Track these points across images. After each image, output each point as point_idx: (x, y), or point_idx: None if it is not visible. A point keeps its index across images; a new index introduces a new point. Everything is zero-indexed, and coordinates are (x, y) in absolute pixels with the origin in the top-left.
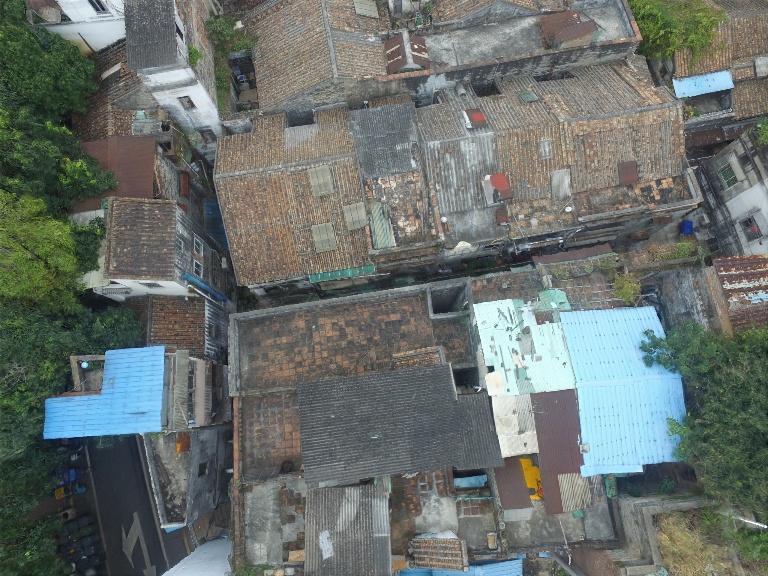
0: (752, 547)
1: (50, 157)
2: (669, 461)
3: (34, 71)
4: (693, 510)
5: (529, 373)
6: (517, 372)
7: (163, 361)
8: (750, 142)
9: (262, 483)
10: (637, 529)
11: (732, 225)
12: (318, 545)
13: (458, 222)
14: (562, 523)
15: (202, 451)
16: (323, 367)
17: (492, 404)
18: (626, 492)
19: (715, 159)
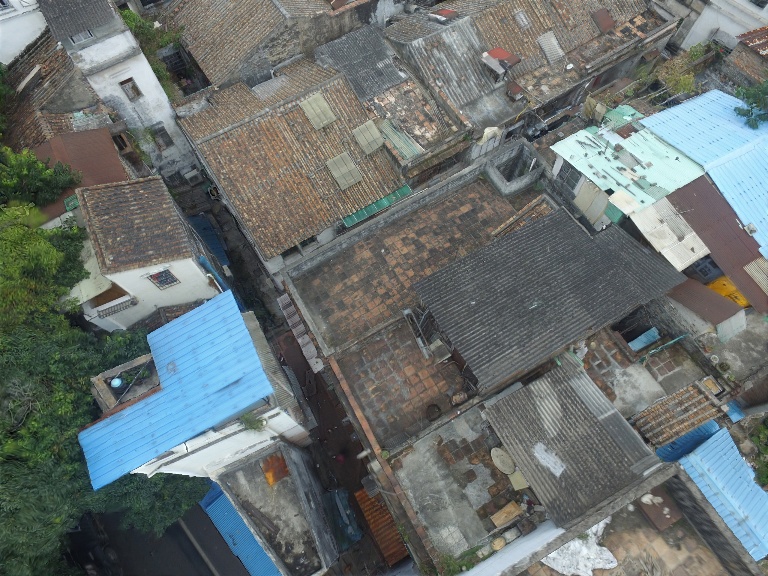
0: None
1: None
2: None
3: None
4: None
5: (650, 180)
6: (637, 184)
7: (236, 307)
8: None
9: (411, 450)
10: None
11: None
12: (539, 465)
13: (473, 113)
14: (764, 336)
15: (299, 476)
16: None
17: (634, 223)
18: None
19: None
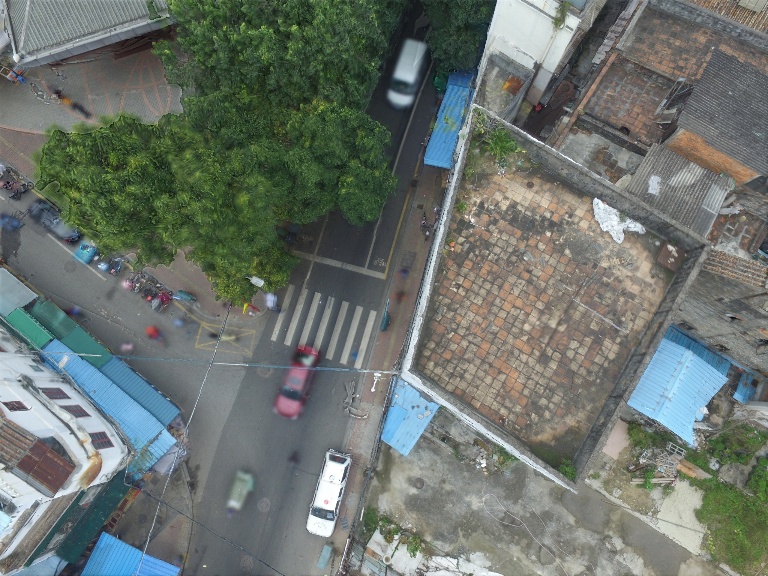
0: None
1: None
2: None
3: None
4: None
5: None
6: None
7: None
8: None
9: (589, 134)
10: None
11: None
12: (647, 181)
13: None
14: None
15: None
16: None
17: None
18: None
19: None
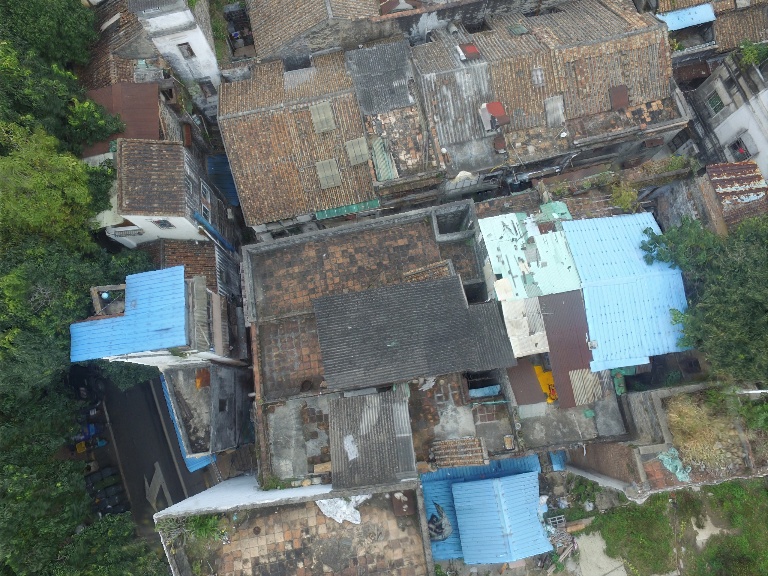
0: (757, 416)
1: (58, 98)
2: (674, 351)
3: (37, 16)
4: (699, 394)
5: (536, 278)
6: (524, 278)
7: (183, 280)
8: (734, 64)
9: (284, 404)
10: (647, 416)
11: (721, 151)
12: (343, 448)
13: (457, 153)
14: (575, 423)
15: (221, 387)
16: (336, 292)
17: (502, 309)
18: (634, 390)
19: (701, 88)
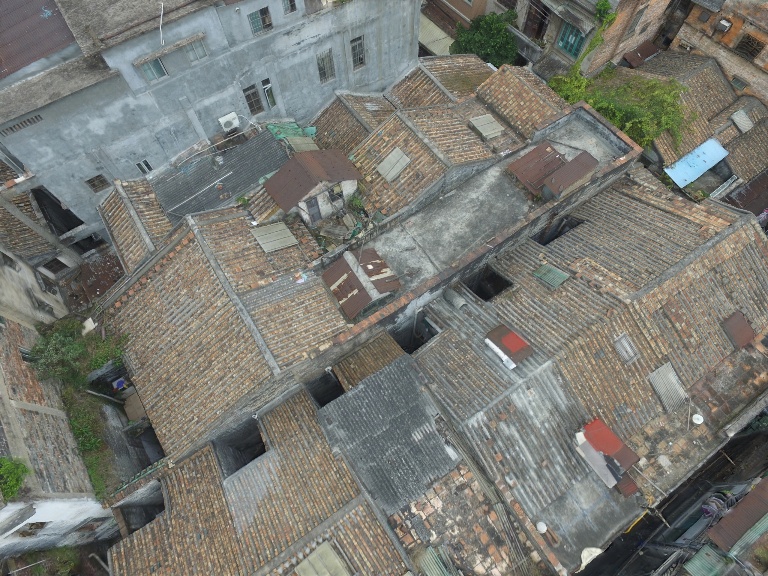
0: None
1: None
2: None
3: None
4: None
5: None
6: None
7: None
8: None
9: None
10: None
11: None
12: None
13: (561, 517)
14: None
15: None
16: None
17: None
18: None
19: None
